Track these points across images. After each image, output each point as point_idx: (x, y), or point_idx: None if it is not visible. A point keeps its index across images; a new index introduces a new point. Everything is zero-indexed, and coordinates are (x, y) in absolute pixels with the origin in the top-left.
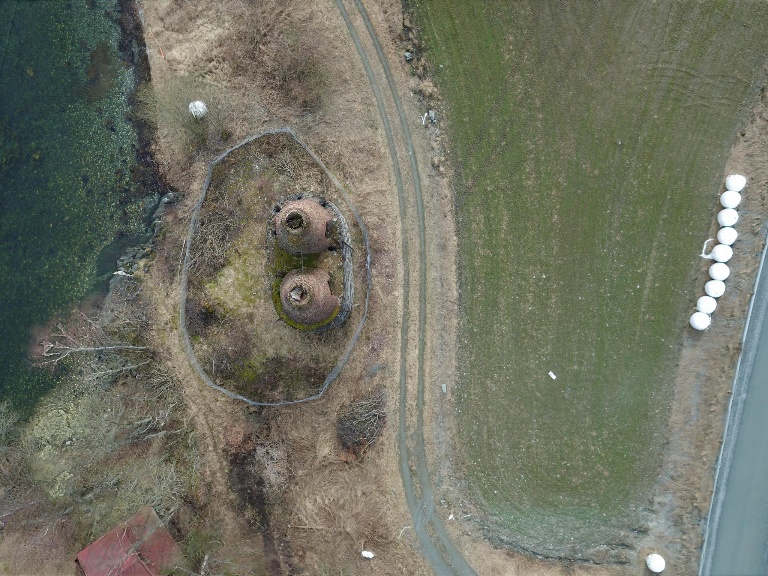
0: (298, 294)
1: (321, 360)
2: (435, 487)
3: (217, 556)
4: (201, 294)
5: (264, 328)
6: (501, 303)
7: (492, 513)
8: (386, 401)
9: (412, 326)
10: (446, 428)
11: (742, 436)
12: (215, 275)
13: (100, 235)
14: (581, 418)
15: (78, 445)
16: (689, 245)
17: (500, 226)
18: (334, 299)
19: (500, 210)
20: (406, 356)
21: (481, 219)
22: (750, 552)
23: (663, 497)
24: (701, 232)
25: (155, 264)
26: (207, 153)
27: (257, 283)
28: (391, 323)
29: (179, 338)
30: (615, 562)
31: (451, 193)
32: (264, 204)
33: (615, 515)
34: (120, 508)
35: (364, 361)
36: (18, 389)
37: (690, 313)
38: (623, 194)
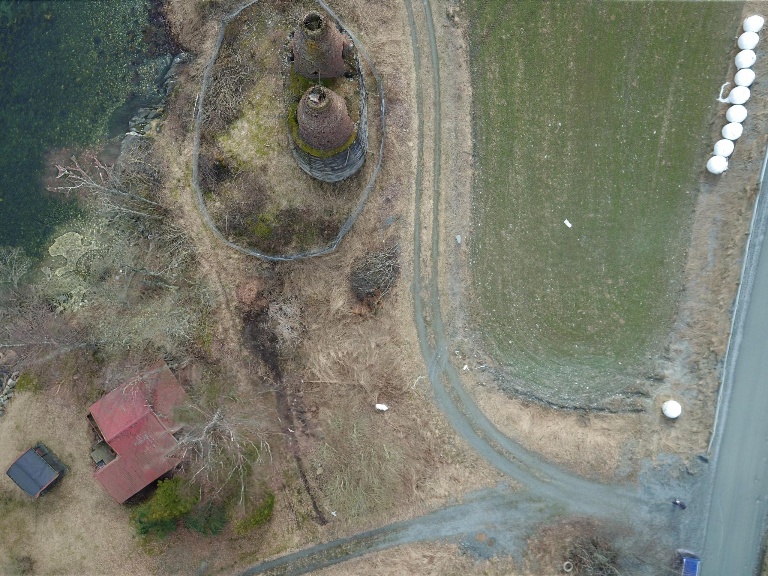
0: (316, 96)
1: (335, 212)
2: (449, 338)
3: (230, 412)
4: (214, 149)
5: (277, 180)
6: (516, 152)
7: (507, 363)
8: (400, 252)
9: (426, 176)
10: (460, 279)
11: (759, 278)
12: (228, 128)
13: (112, 96)
14: (597, 266)
15: (90, 306)
16: (706, 89)
17: (515, 75)
18: (351, 123)
19: (515, 59)
20: (420, 206)
21: (496, 68)
22: (767, 396)
23: (679, 344)
24: (718, 76)
25: (167, 123)
26: (220, 12)
27: (270, 135)
28: (405, 174)
29: (191, 195)
30: (631, 410)
31: (466, 43)
32: (278, 55)
33: (631, 363)
34: (132, 367)
35: (378, 212)
36: (29, 251)
37: (707, 158)
38: (640, 39)
